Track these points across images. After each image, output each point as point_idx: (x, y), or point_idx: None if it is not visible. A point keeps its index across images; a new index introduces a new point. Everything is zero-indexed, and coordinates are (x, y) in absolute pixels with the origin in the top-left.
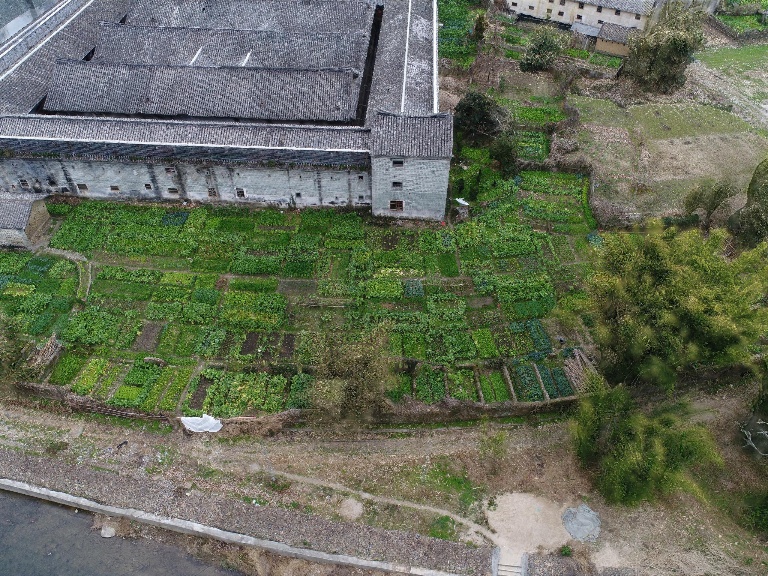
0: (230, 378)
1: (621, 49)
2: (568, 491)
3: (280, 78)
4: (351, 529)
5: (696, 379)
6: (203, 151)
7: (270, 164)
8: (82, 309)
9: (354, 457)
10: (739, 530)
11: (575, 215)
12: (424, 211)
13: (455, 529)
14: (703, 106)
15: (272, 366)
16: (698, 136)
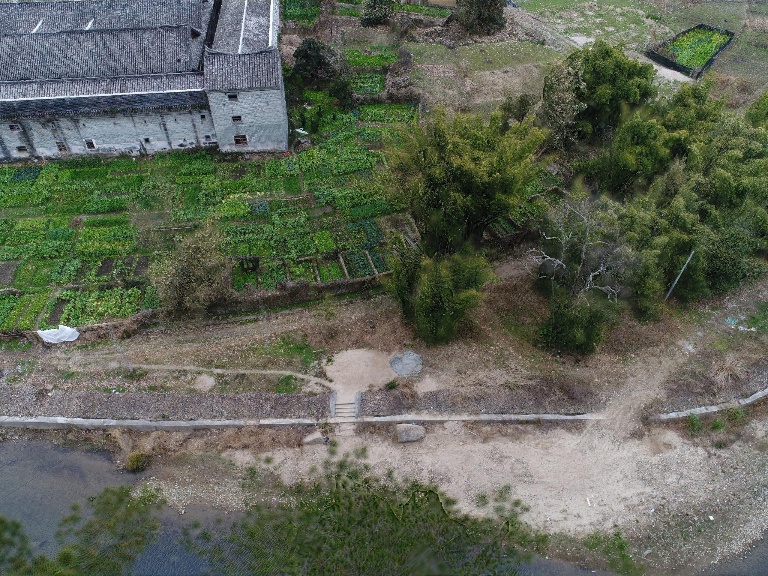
0: (86, 296)
1: (450, 1)
2: (395, 343)
3: (120, 38)
4: (205, 398)
5: (502, 245)
6: (44, 104)
7: (113, 111)
8: None
9: (207, 344)
10: (535, 350)
11: (407, 136)
12: (267, 143)
13: (298, 384)
14: (522, 42)
15: (125, 281)
16: (516, 66)
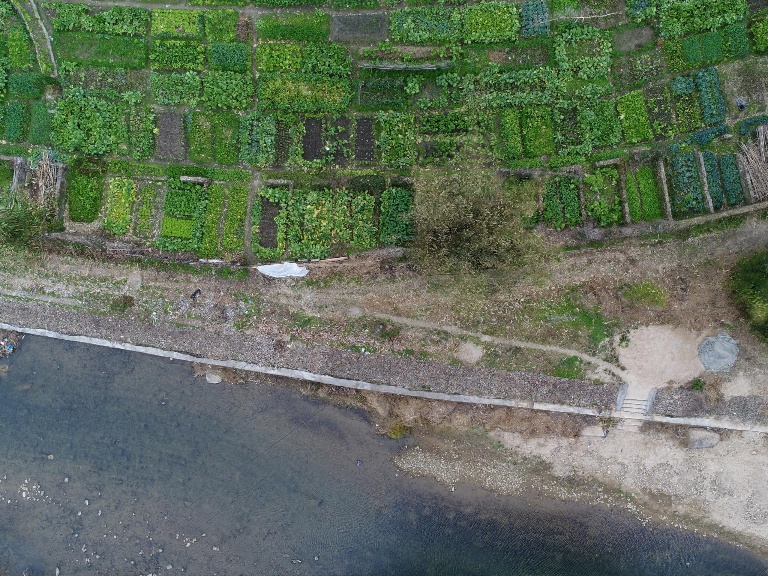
0: (301, 200)
1: None
2: (710, 318)
3: None
4: (471, 372)
5: None
6: None
7: None
8: (59, 92)
9: (468, 292)
10: None
11: None
12: None
13: (582, 367)
14: None
15: (353, 182)
16: None
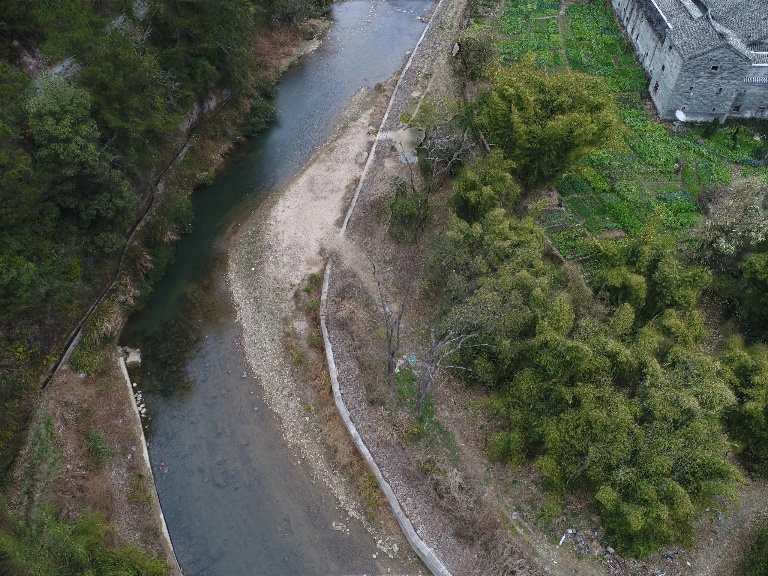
0: None
1: None
2: None
3: (763, 5)
4: None
5: None
6: None
7: (649, 19)
8: None
9: None
10: None
11: None
12: (660, 103)
13: None
14: None
15: None
16: None
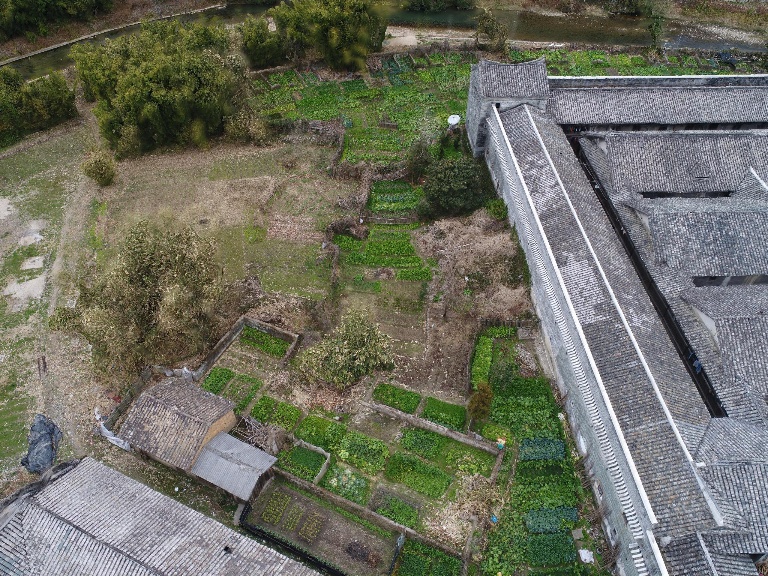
0: None
1: None
2: None
3: None
4: None
5: None
6: None
7: None
8: None
9: None
10: None
11: None
12: None
13: None
14: None
15: None
16: None
